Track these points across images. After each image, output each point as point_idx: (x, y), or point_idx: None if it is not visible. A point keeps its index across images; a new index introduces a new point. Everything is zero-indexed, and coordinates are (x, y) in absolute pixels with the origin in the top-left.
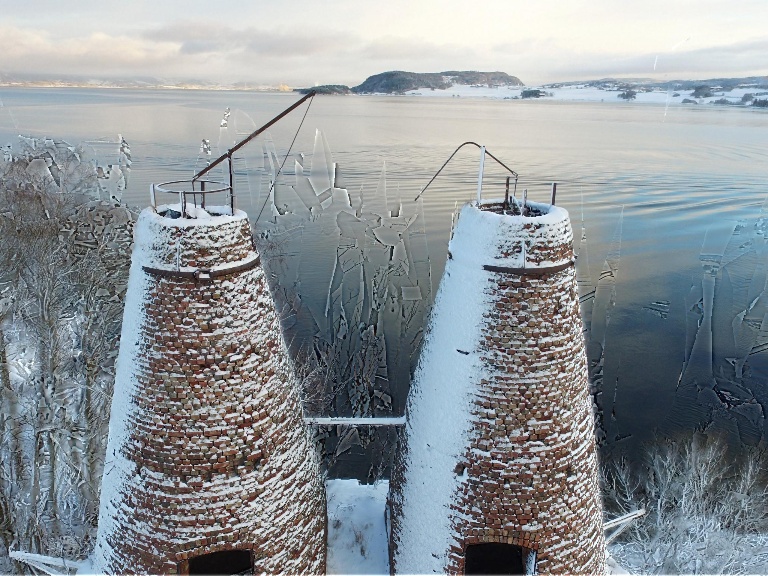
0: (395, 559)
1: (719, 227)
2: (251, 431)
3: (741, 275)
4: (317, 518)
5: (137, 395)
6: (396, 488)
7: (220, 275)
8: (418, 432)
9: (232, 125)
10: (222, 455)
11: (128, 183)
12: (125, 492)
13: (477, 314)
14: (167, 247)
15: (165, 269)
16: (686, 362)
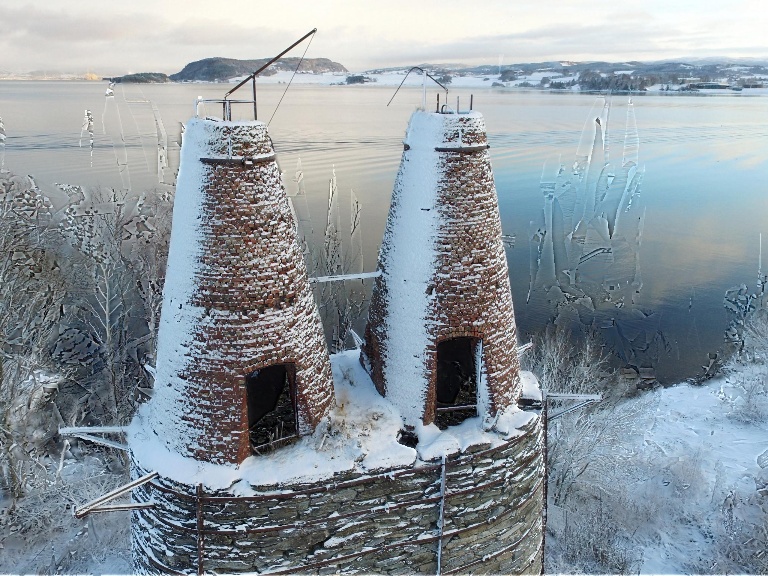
0: (384, 372)
1: (552, 159)
2: (287, 277)
3: (566, 207)
4: (326, 350)
5: (203, 256)
6: (379, 323)
7: (258, 162)
8: (396, 274)
9: None
10: (270, 294)
11: (2, 158)
12: (196, 332)
13: (434, 182)
14: (221, 142)
15: (221, 158)
16: (532, 282)
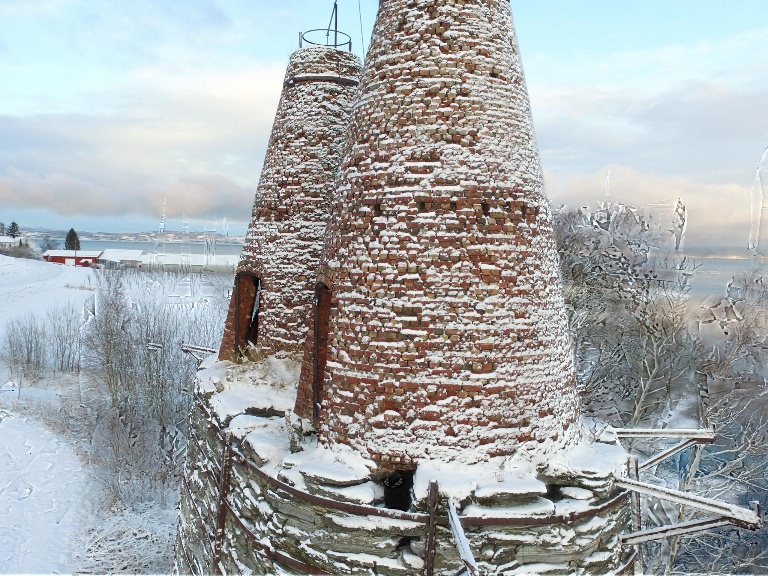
0: None
1: None
2: None
3: None
4: None
5: None
6: None
7: (300, 81)
8: None
9: (761, 162)
10: None
11: (678, 243)
12: None
13: None
14: None
15: None
16: None
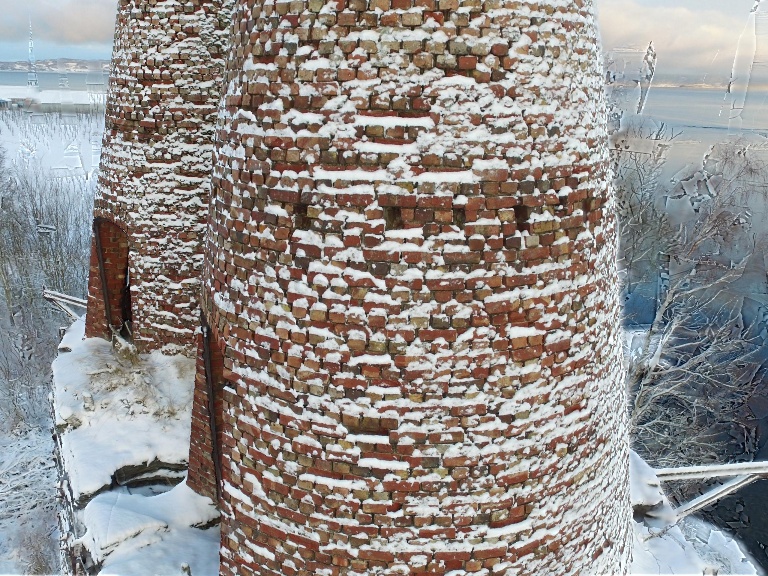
0: None
1: None
2: (149, 91)
3: None
4: None
5: None
6: None
7: None
8: None
9: (759, 4)
10: (123, 110)
11: (643, 97)
12: None
13: None
14: None
15: None
16: None
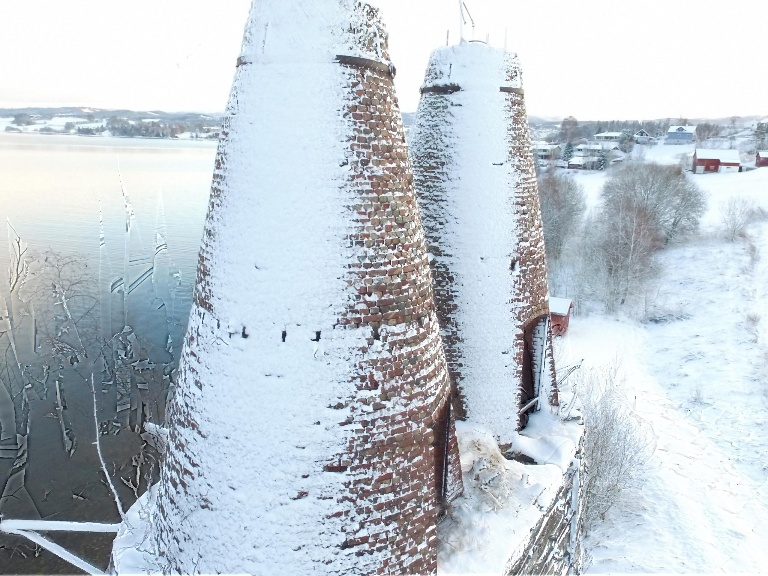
0: (461, 386)
1: None
2: None
3: None
4: None
5: (359, 232)
6: None
7: None
8: (467, 252)
9: None
10: None
11: None
12: (361, 374)
13: (504, 129)
14: (366, 29)
15: (370, 58)
16: None
